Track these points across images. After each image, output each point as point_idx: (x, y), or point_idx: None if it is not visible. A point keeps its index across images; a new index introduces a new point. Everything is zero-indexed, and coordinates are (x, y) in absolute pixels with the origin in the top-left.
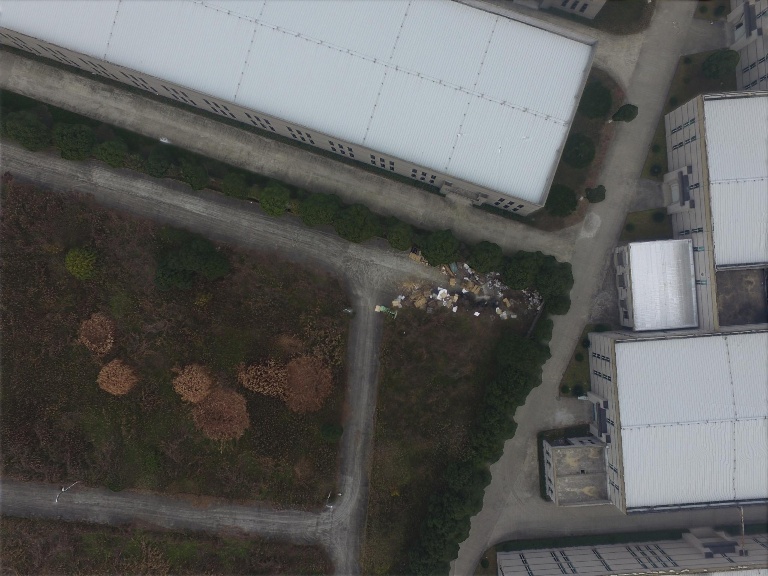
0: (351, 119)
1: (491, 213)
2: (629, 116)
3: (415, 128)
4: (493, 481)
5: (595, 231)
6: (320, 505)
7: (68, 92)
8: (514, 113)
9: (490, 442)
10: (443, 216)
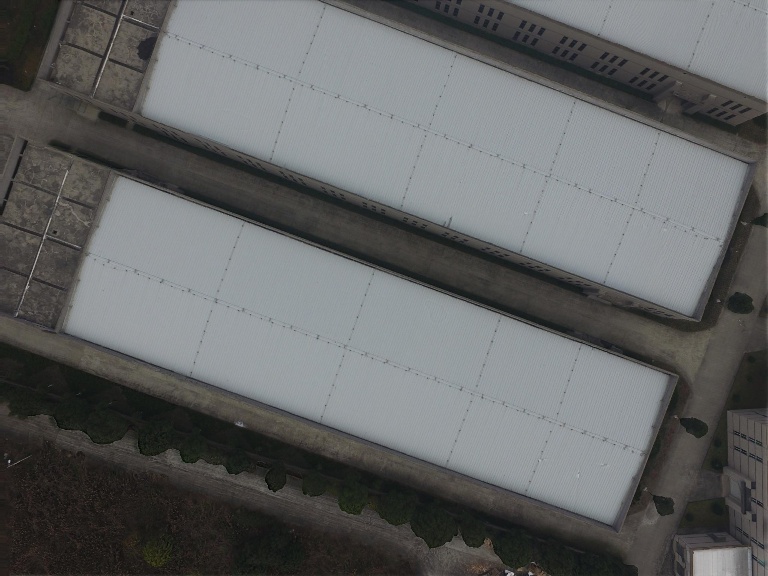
0: (435, 442)
1: None
2: (700, 435)
3: (498, 452)
4: None
5: (656, 519)
6: None
7: (142, 373)
8: (594, 442)
9: None
10: (513, 503)
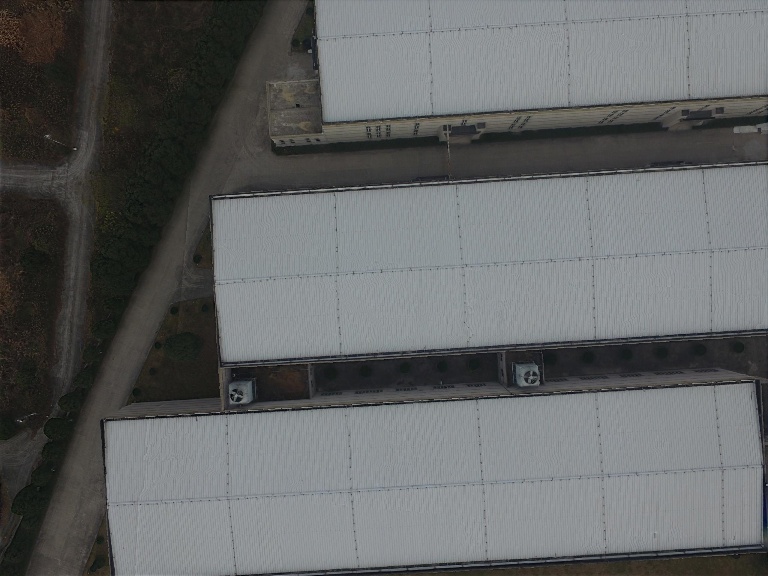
0: None
1: None
2: None
3: None
4: (225, 135)
5: None
6: (51, 153)
7: None
8: None
9: (199, 66)
10: None
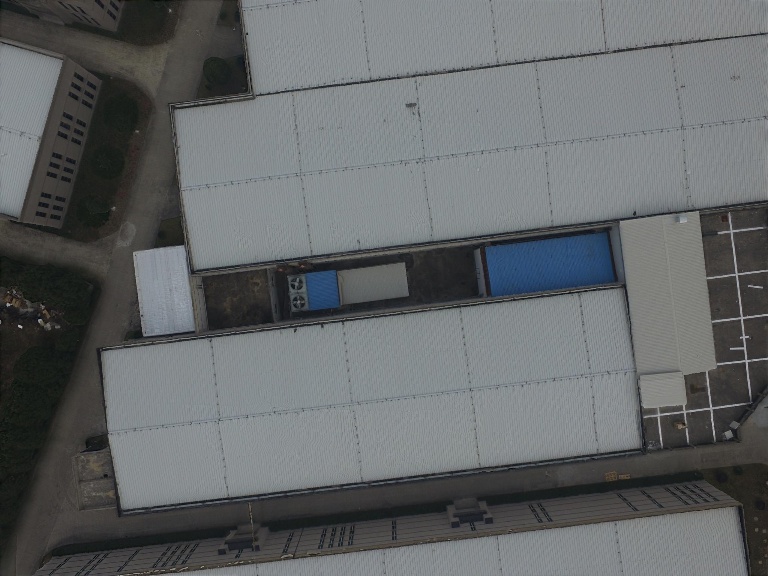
0: None
1: (29, 227)
2: (118, 127)
3: None
4: (47, 488)
5: (131, 240)
6: None
7: None
8: None
9: (2, 452)
10: None
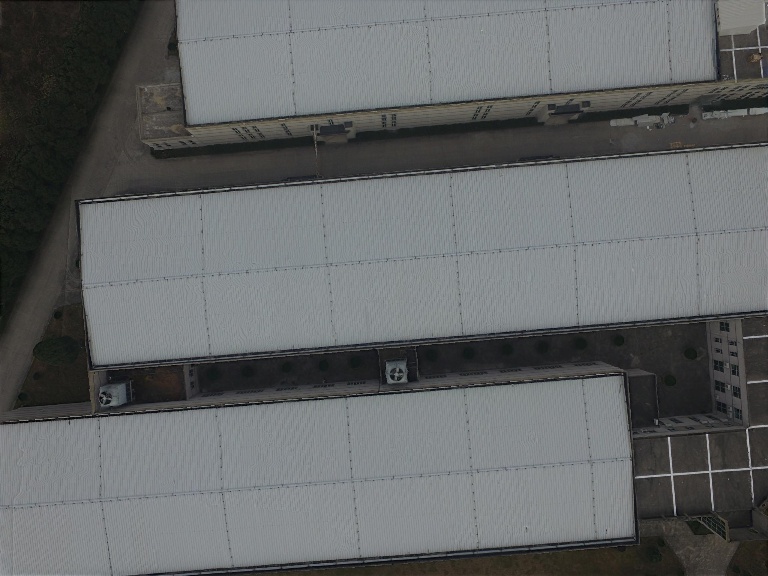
0: None
1: None
2: None
3: None
4: (105, 140)
5: None
6: None
7: None
8: None
9: (67, 72)
10: None
